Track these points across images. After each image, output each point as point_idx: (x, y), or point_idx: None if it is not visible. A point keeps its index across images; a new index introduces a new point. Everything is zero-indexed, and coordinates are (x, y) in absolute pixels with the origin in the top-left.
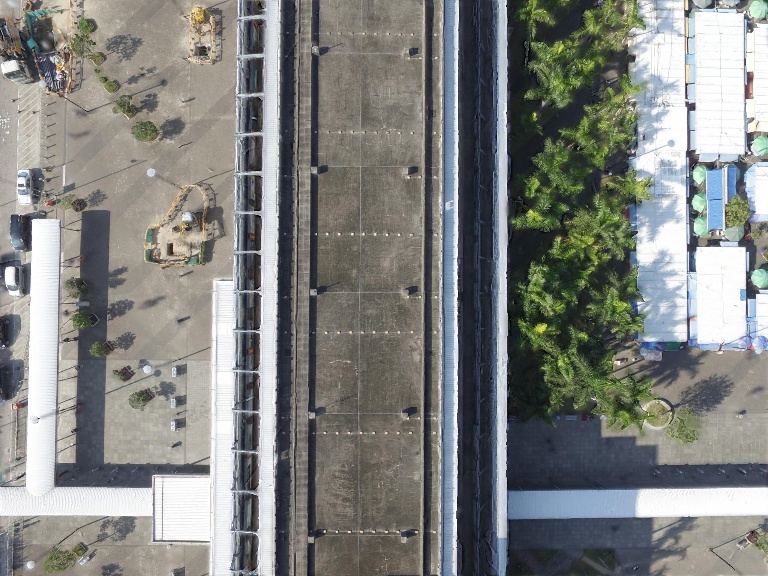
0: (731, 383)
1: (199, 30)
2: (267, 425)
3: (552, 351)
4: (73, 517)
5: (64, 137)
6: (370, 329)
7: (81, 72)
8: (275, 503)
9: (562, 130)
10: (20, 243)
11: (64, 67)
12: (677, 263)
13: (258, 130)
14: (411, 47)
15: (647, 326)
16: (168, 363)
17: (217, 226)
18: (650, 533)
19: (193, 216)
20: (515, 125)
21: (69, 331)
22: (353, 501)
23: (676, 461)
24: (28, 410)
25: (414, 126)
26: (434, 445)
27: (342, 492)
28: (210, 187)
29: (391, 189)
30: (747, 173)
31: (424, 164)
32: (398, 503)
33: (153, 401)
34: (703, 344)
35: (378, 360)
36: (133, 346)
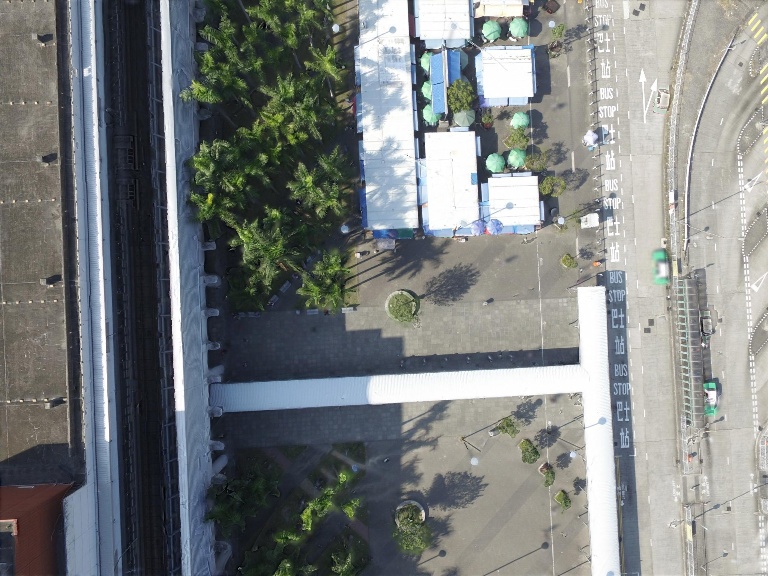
0: (477, 272)
1: None
2: None
3: (242, 229)
4: None
5: None
6: (10, 199)
7: None
8: None
9: (249, 9)
10: None
11: None
12: (405, 150)
13: None
14: None
15: (376, 214)
16: None
17: None
18: (400, 424)
19: None
20: (207, 9)
21: None
22: None
23: (423, 352)
24: None
25: None
26: None
27: None
28: None
29: (26, 58)
30: (476, 58)
31: (55, 30)
32: (46, 372)
33: None
34: (435, 230)
35: (20, 229)
36: None
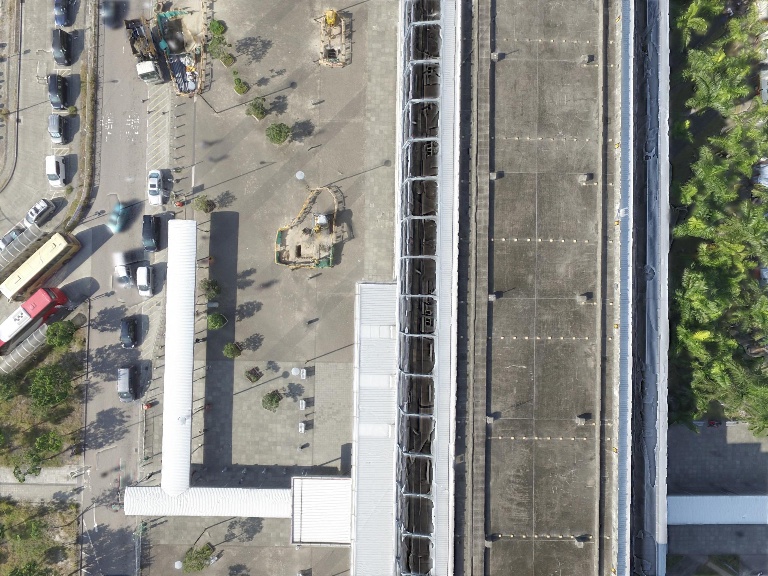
0: None
1: (329, 33)
2: (442, 429)
3: (703, 358)
4: (200, 517)
5: (193, 138)
6: (545, 335)
7: (210, 73)
8: (454, 507)
9: (712, 138)
10: (151, 243)
11: (194, 68)
12: None
13: (418, 135)
14: (587, 54)
15: None
16: (296, 365)
17: (346, 229)
18: None
19: (326, 219)
20: None
21: (197, 332)
22: (528, 506)
23: None
24: (164, 410)
25: (589, 133)
26: (608, 451)
27: (517, 497)
28: (339, 190)
29: (567, 195)
30: None
31: (601, 171)
32: (572, 508)
33: (281, 402)
34: None
35: (553, 366)
36: (261, 347)
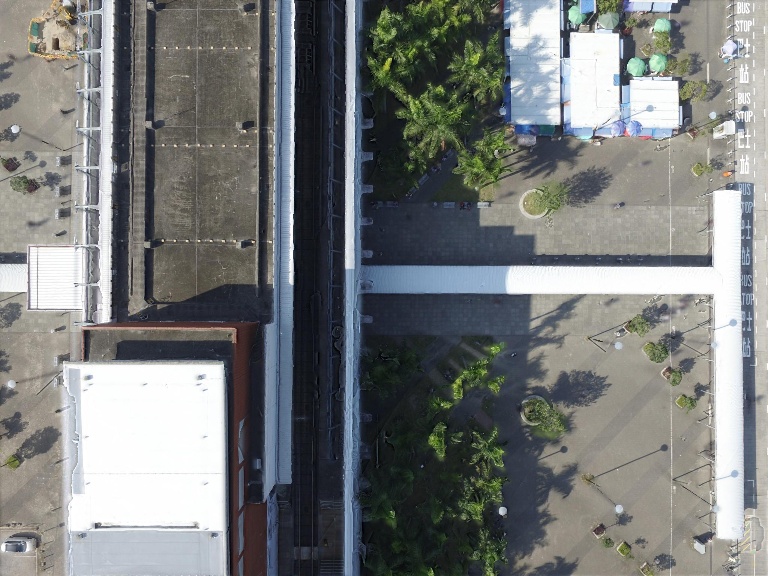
0: (609, 175)
1: None
2: (107, 138)
3: (408, 103)
4: None
5: None
6: (208, 45)
7: None
8: (111, 207)
9: None
10: None
11: None
12: (550, 48)
13: None
14: None
15: (520, 109)
16: (53, 154)
17: None
18: (528, 321)
19: (74, 4)
20: None
21: None
22: (191, 212)
23: (554, 251)
24: None
25: None
26: (271, 158)
27: (180, 203)
28: None
29: None
30: None
31: None
32: (235, 214)
33: (38, 191)
34: (576, 128)
35: (216, 75)
36: (19, 138)
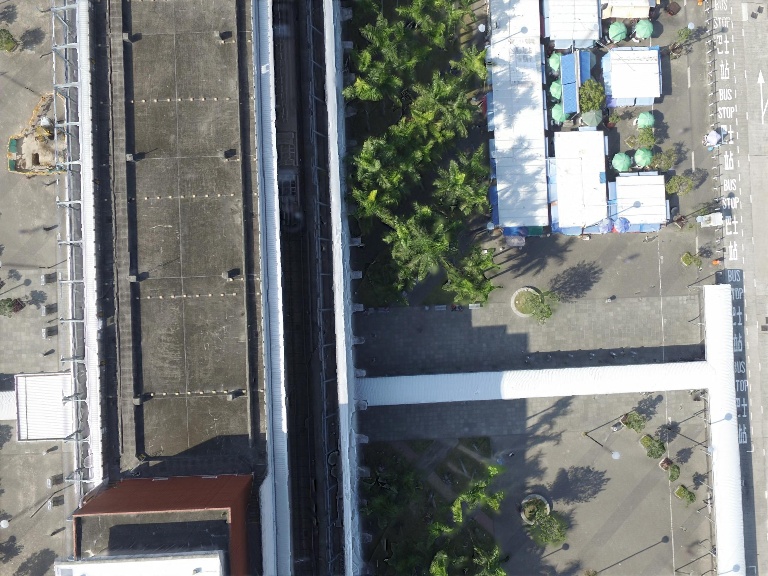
0: (599, 269)
1: None
2: (91, 292)
3: None
4: None
5: None
6: (190, 193)
7: None
8: (98, 366)
9: (399, 9)
10: None
11: None
12: (535, 148)
13: None
14: None
15: (508, 211)
16: (38, 272)
17: None
18: (524, 419)
19: (53, 122)
20: (355, 8)
21: None
22: (180, 364)
23: (548, 348)
24: None
25: None
26: (259, 305)
27: (168, 355)
28: None
29: (206, 54)
30: (603, 58)
31: (236, 27)
32: (225, 364)
33: (24, 310)
34: (565, 228)
35: (199, 224)
36: (2, 257)
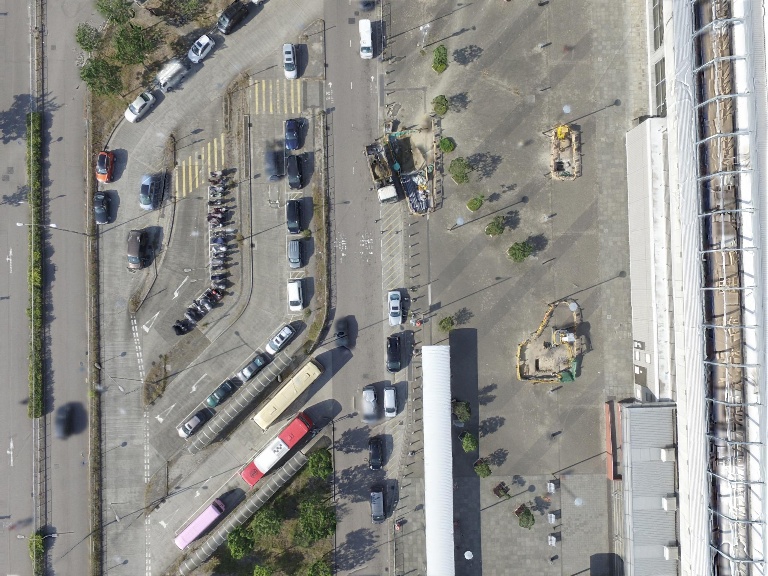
0: None
1: (558, 146)
2: None
3: None
4: None
5: (428, 256)
6: None
7: (441, 191)
8: None
9: None
10: (396, 365)
11: (425, 186)
12: None
13: (708, 271)
14: None
15: None
16: (541, 478)
17: (584, 341)
18: None
19: None
20: None
21: None
22: None
23: None
24: (426, 535)
25: None
26: None
27: None
28: (576, 302)
29: None
30: None
31: None
32: None
33: None
34: None
35: None
36: (506, 462)
